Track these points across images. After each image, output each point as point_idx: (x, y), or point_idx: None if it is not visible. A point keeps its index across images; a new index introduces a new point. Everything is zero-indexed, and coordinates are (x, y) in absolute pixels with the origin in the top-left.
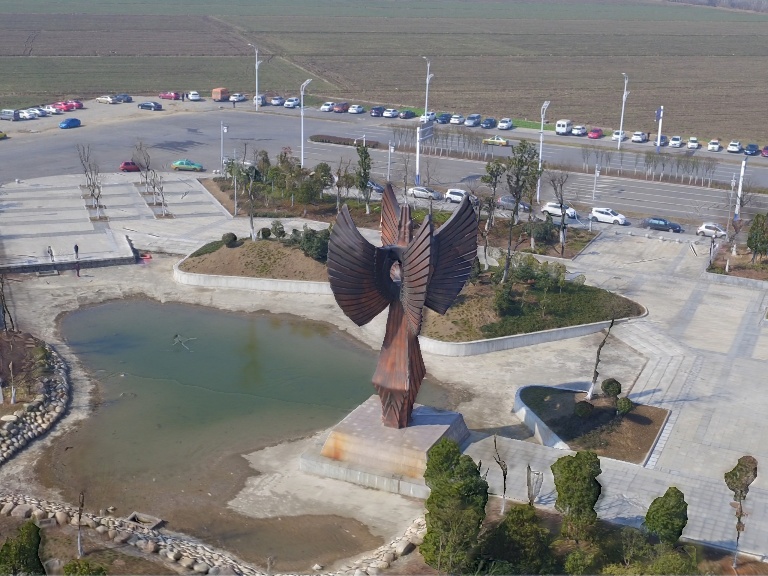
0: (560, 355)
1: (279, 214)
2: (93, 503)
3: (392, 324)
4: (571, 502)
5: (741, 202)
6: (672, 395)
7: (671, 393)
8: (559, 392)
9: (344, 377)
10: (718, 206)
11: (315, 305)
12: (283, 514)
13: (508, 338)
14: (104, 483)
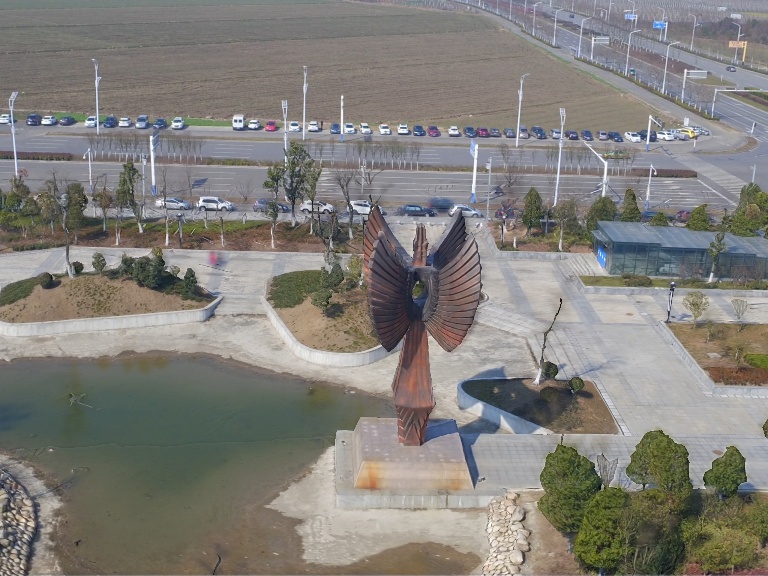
0: None
1: (47, 244)
2: None
3: (411, 344)
4: (674, 478)
5: (509, 183)
6: (580, 367)
7: (577, 366)
8: (498, 382)
9: (276, 406)
10: (441, 187)
11: (176, 337)
12: (365, 555)
13: None
14: (157, 570)
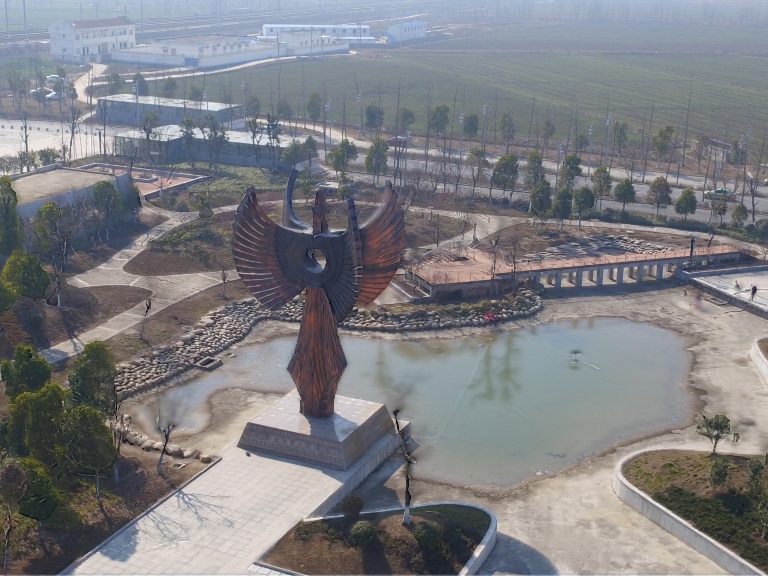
0: (663, 567)
1: None
2: (243, 351)
3: None
4: None
5: None
6: None
7: None
8: (457, 522)
9: (529, 434)
10: None
11: (745, 415)
12: (216, 406)
13: (667, 513)
14: (275, 352)
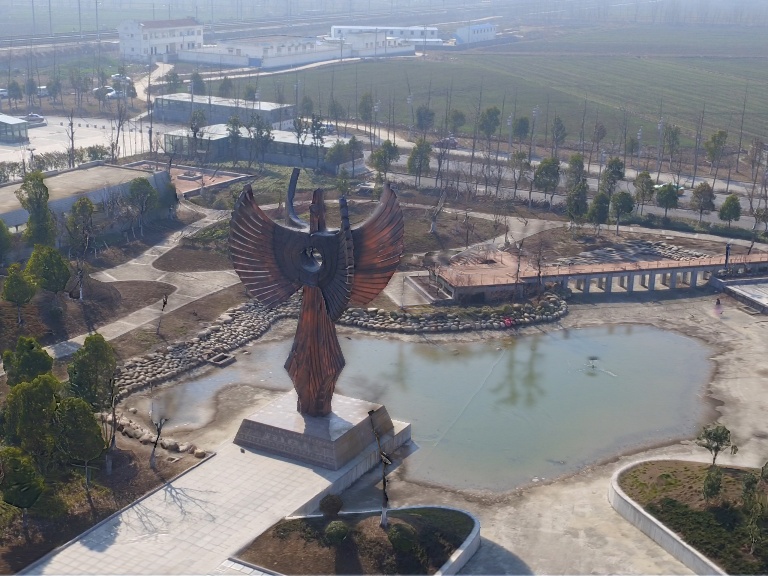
0: None
1: None
2: (259, 348)
3: None
4: None
5: None
6: None
7: None
8: (438, 526)
9: (532, 440)
10: None
11: (760, 428)
12: (222, 403)
13: (657, 525)
14: None
